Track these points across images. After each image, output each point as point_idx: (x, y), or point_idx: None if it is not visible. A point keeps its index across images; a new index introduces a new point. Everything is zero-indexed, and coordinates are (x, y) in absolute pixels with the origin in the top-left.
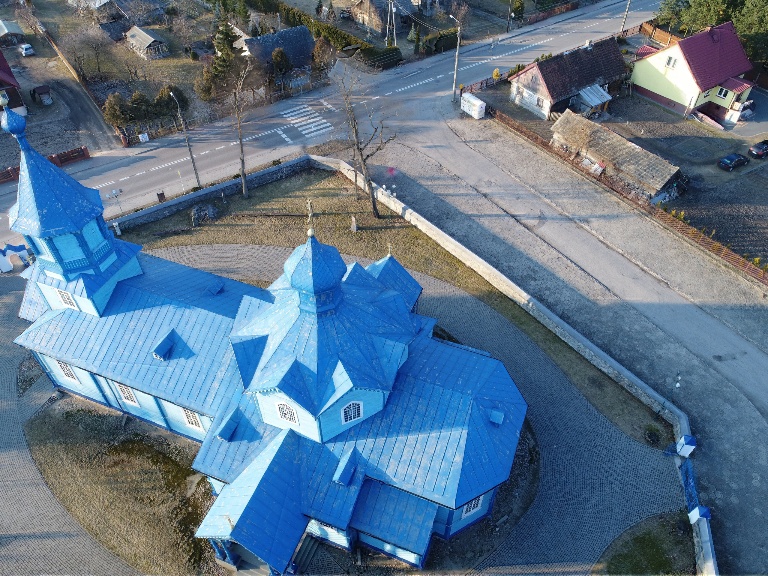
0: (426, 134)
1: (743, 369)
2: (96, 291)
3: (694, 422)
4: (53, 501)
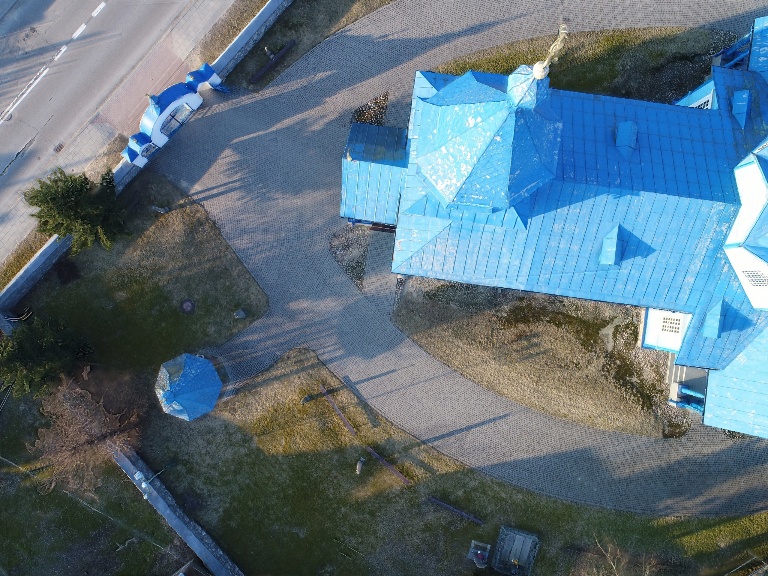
0: None
1: None
2: (527, 214)
3: None
4: (480, 390)
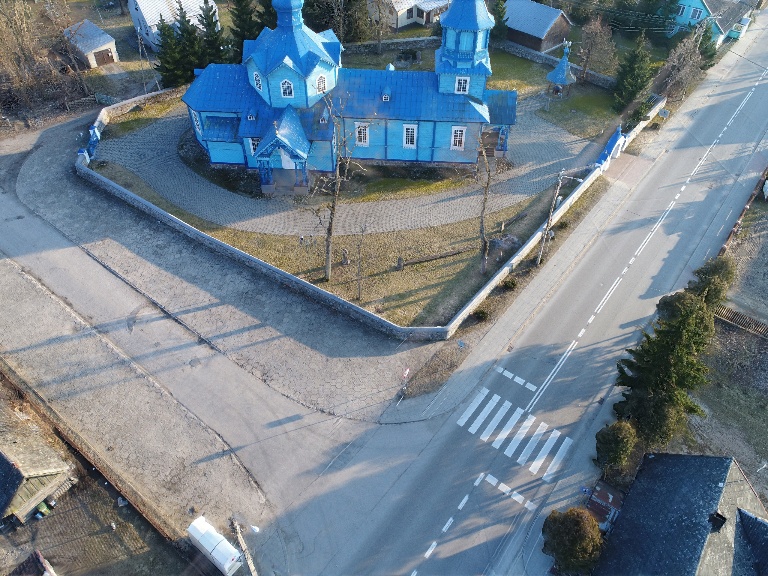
0: (300, 451)
1: (5, 213)
2: None
3: (69, 176)
4: None
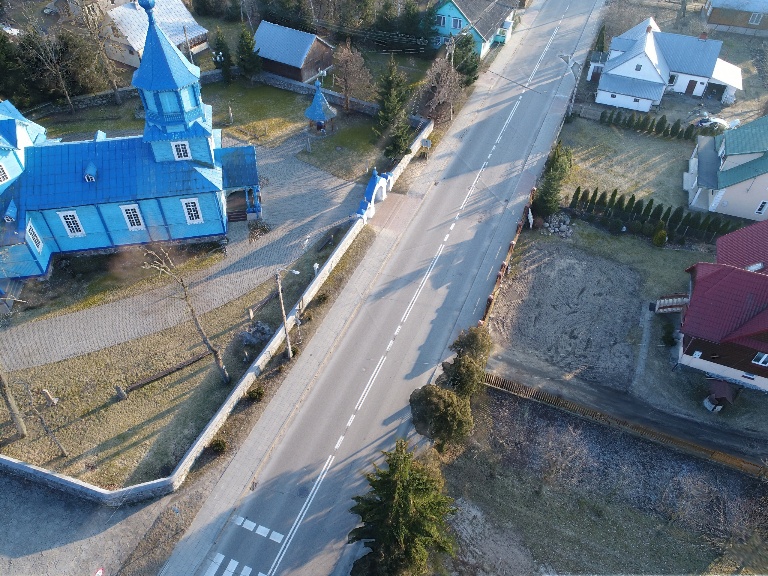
0: None
1: None
2: None
3: None
4: None
